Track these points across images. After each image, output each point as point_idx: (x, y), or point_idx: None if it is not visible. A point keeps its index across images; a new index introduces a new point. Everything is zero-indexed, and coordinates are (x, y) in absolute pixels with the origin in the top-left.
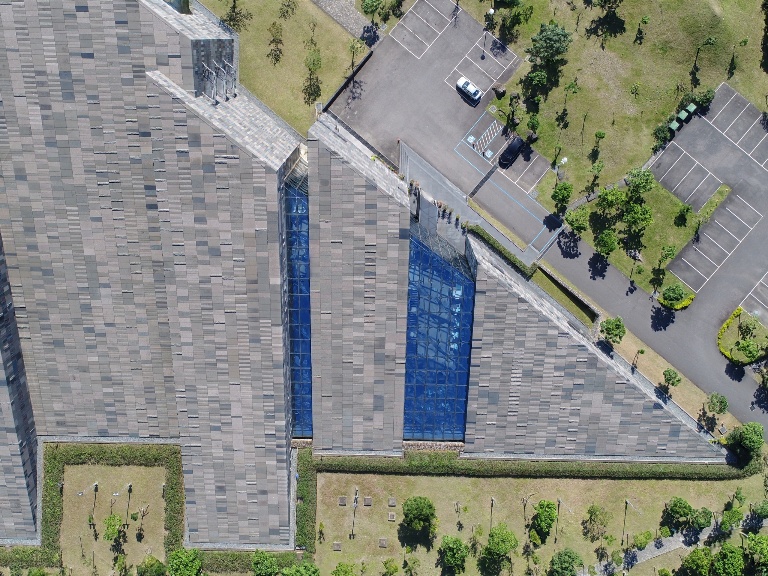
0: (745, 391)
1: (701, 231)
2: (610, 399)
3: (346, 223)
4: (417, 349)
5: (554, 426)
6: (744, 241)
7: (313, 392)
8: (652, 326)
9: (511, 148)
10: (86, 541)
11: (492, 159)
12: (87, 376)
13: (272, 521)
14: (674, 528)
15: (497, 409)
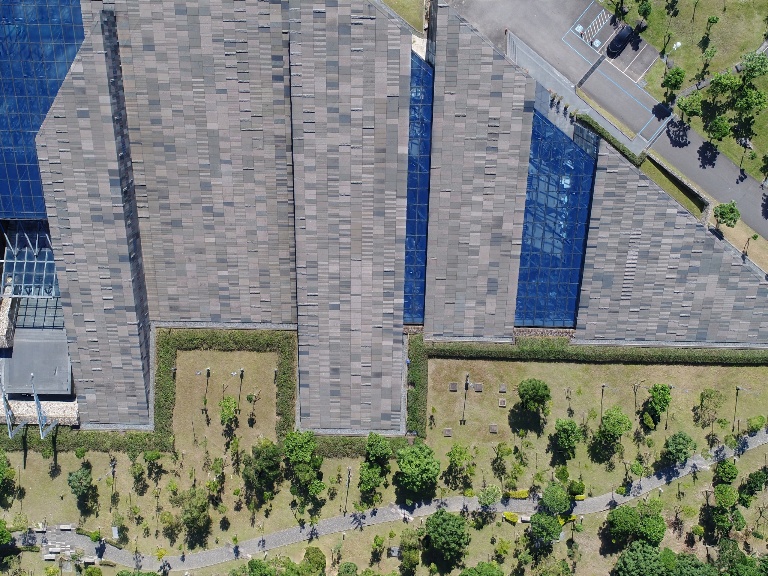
0: None
1: None
2: (725, 282)
3: (471, 95)
4: None
5: (667, 311)
6: None
7: (427, 275)
8: (763, 214)
9: (621, 36)
10: (198, 426)
11: (600, 49)
12: (203, 258)
13: (384, 405)
14: None
15: (611, 293)
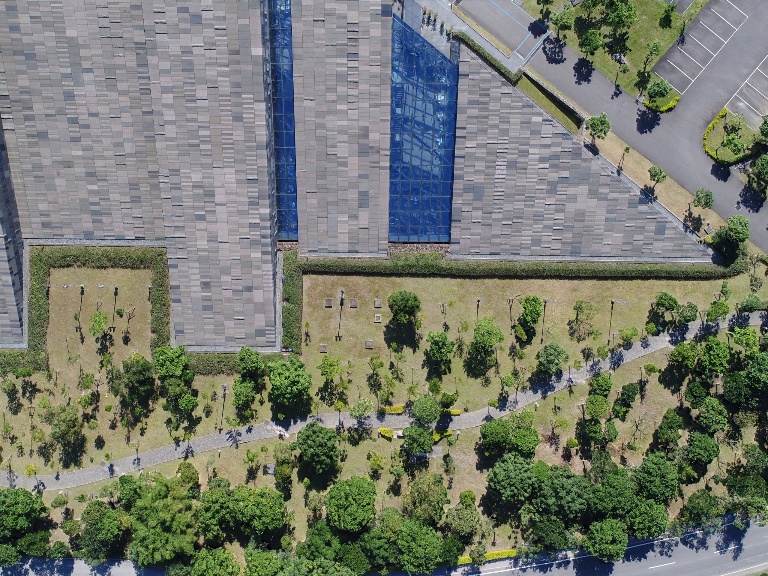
0: (731, 191)
1: (686, 32)
2: (595, 193)
3: None
4: (402, 154)
5: (539, 224)
6: (729, 42)
7: (298, 188)
8: (637, 129)
9: None
10: (72, 344)
11: None
12: (72, 172)
13: (258, 321)
14: (660, 326)
15: (482, 205)
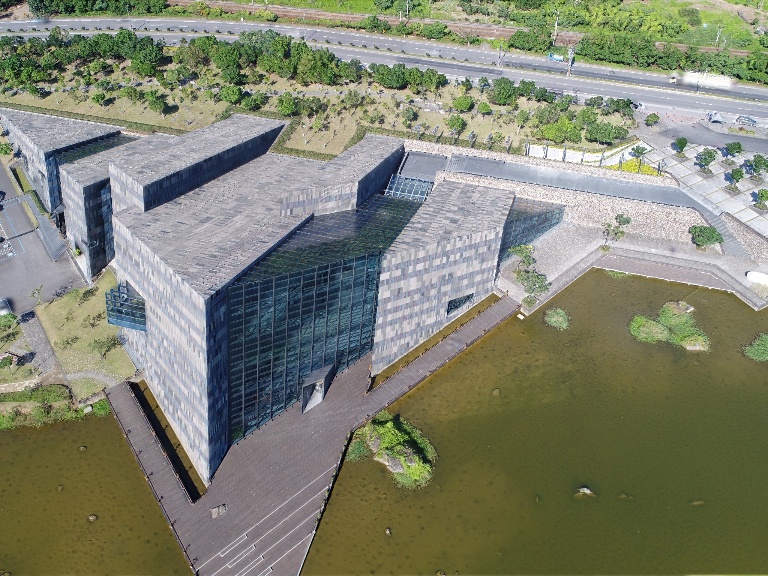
0: None
1: None
2: None
3: None
4: None
5: None
6: None
7: None
8: None
9: None
10: None
11: (7, 244)
12: (301, 171)
13: None
14: (45, 92)
15: None
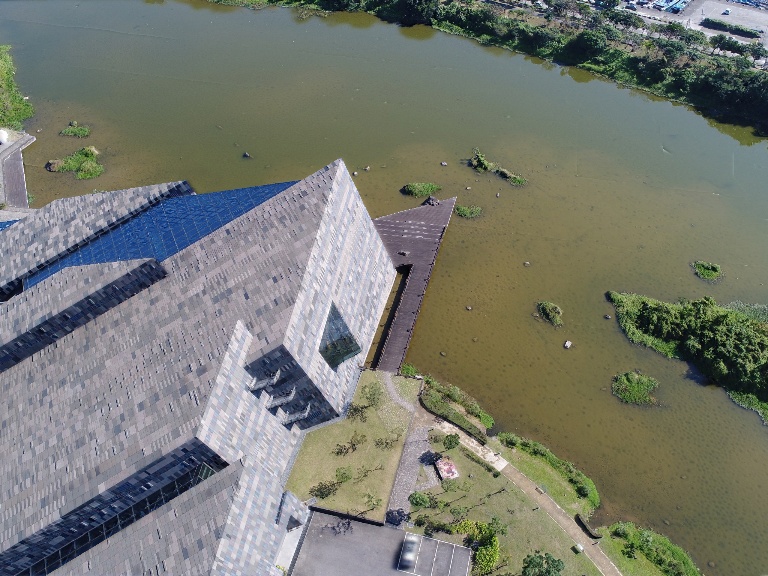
0: None
1: None
2: None
3: (179, 531)
4: None
5: None
6: None
7: None
8: None
9: None
10: None
11: None
12: (5, 411)
13: None
14: None
15: None
